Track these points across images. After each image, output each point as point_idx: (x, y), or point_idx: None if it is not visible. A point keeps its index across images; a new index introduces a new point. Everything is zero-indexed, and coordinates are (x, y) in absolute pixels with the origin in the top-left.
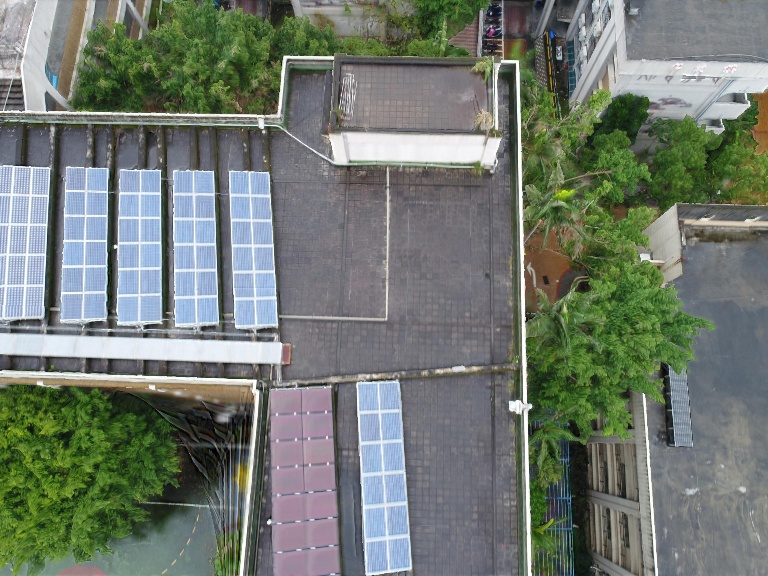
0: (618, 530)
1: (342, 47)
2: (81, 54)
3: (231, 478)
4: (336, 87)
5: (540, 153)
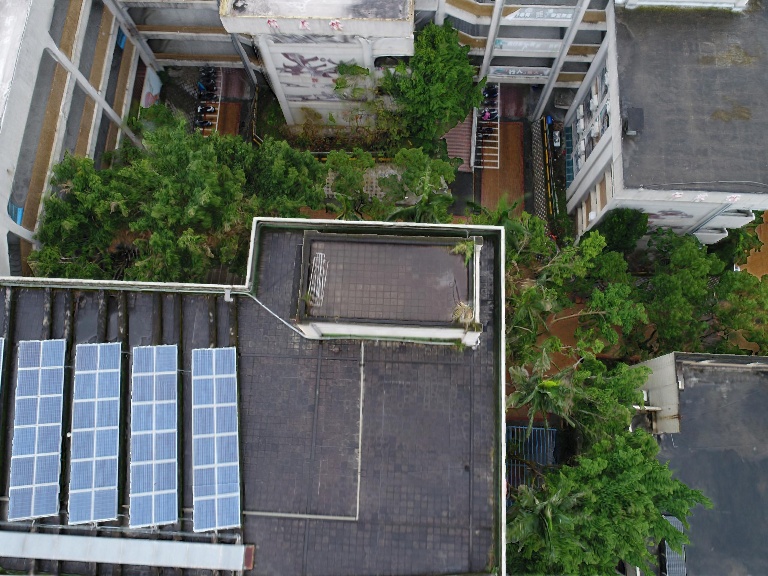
0: None
1: (330, 137)
2: (50, 178)
3: None
4: (305, 269)
5: (528, 305)
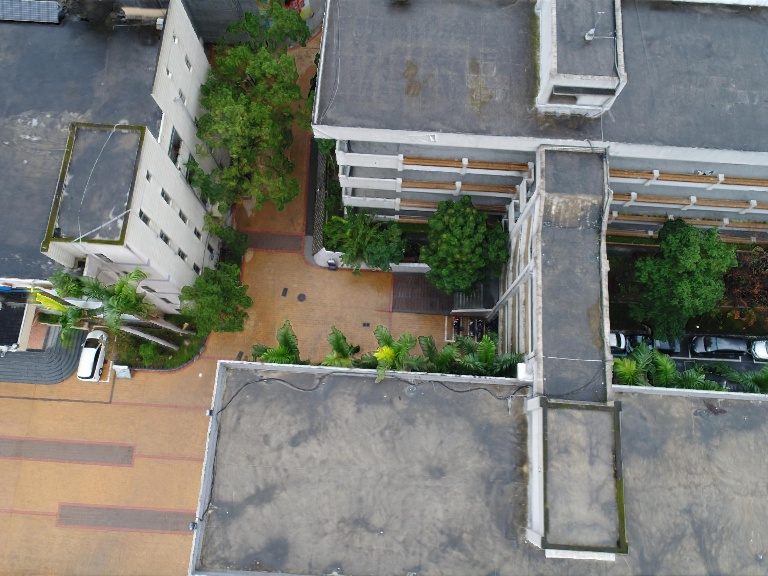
0: None
1: None
2: None
3: None
4: None
5: None
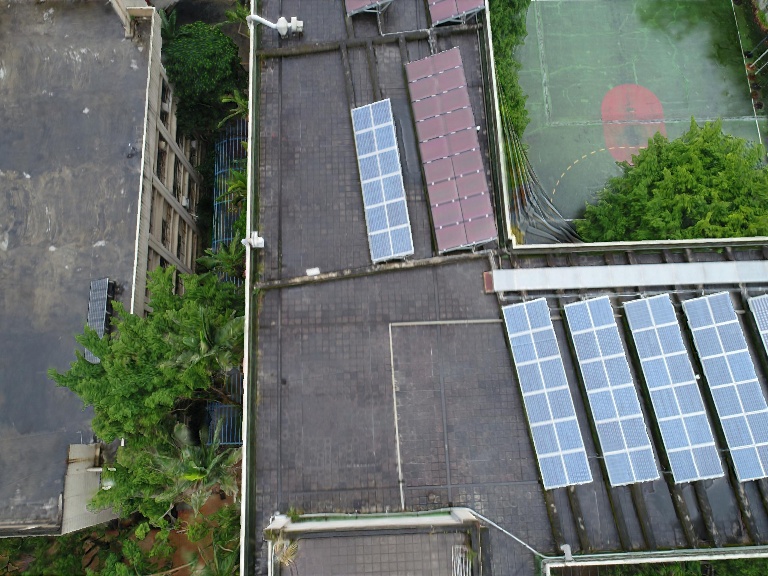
0: (171, 236)
1: None
2: None
3: (521, 179)
4: None
5: None
